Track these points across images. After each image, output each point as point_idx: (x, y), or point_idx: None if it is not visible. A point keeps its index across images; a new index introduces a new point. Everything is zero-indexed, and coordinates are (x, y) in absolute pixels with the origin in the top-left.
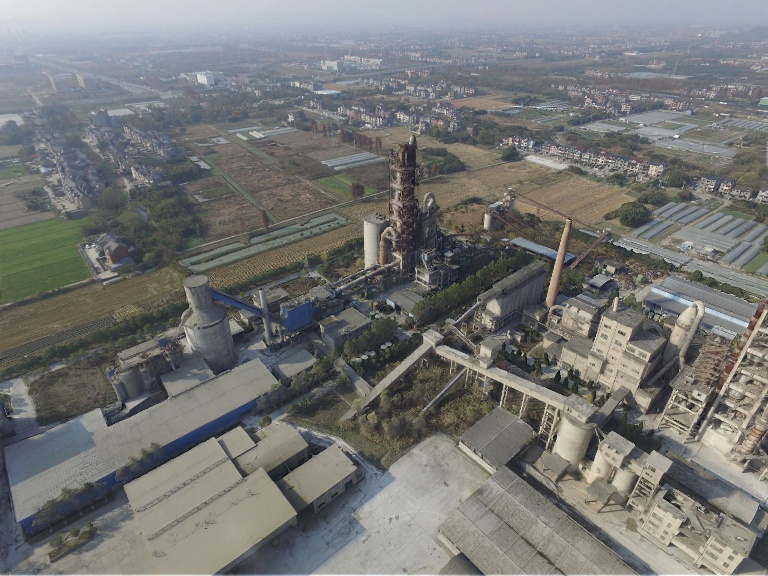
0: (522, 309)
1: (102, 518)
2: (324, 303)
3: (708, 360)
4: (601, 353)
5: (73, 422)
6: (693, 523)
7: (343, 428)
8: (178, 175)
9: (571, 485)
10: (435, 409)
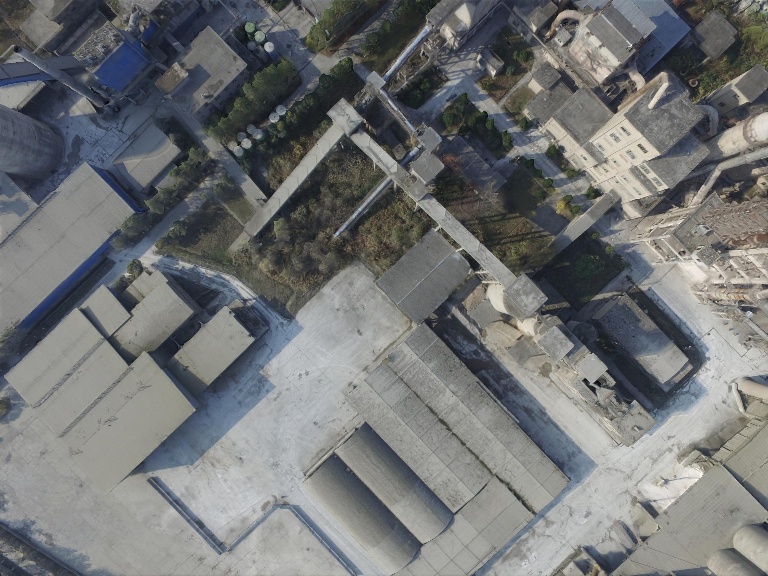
0: (512, 3)
1: (8, 388)
2: (160, 5)
3: (743, 226)
4: (602, 150)
5: None
6: None
7: (236, 263)
8: None
9: (497, 329)
10: (351, 232)
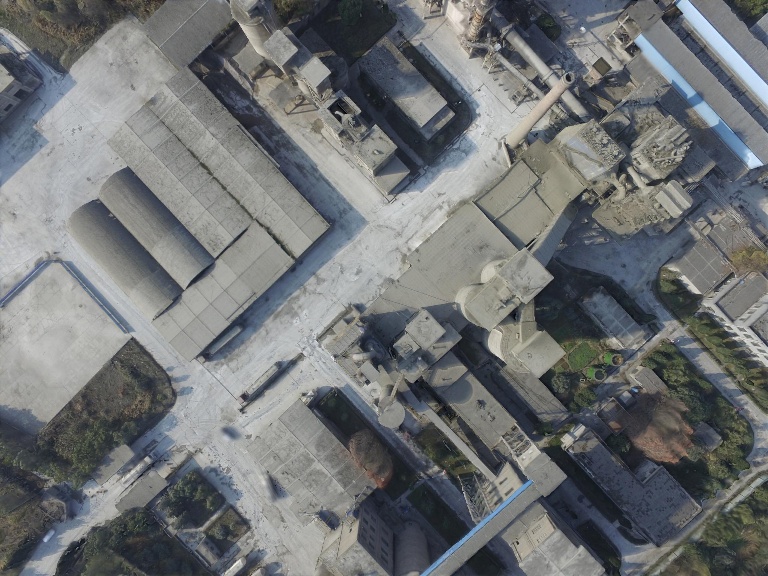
0: None
1: None
2: None
3: None
4: None
5: None
6: None
7: (8, 14)
8: None
9: (269, 83)
10: None
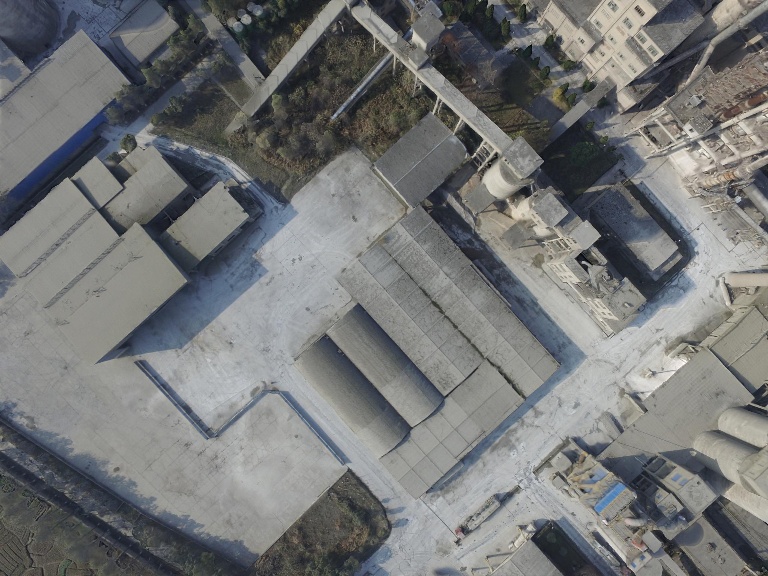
0: None
1: None
2: None
3: (736, 85)
4: (599, 27)
5: None
6: (592, 283)
7: (232, 144)
8: None
9: (492, 218)
10: (348, 115)
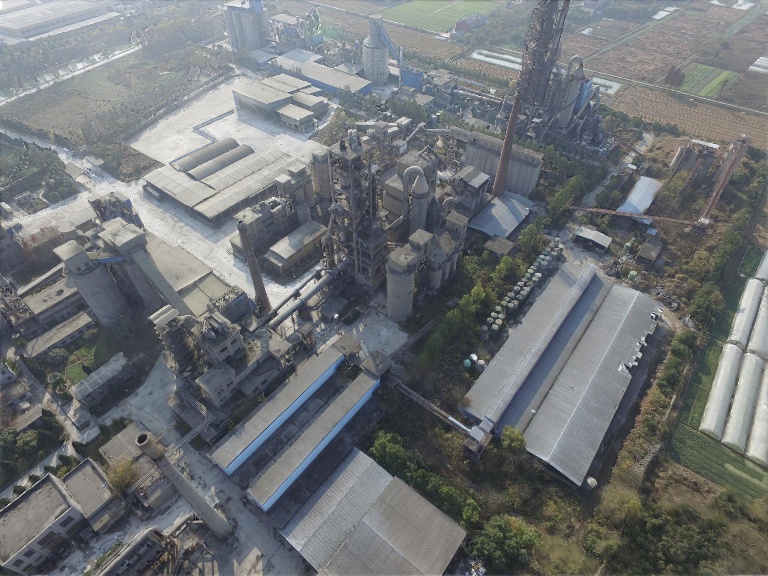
0: None
1: None
2: (442, 92)
3: None
4: None
5: (313, 54)
6: None
7: None
8: (613, 10)
9: None
10: None
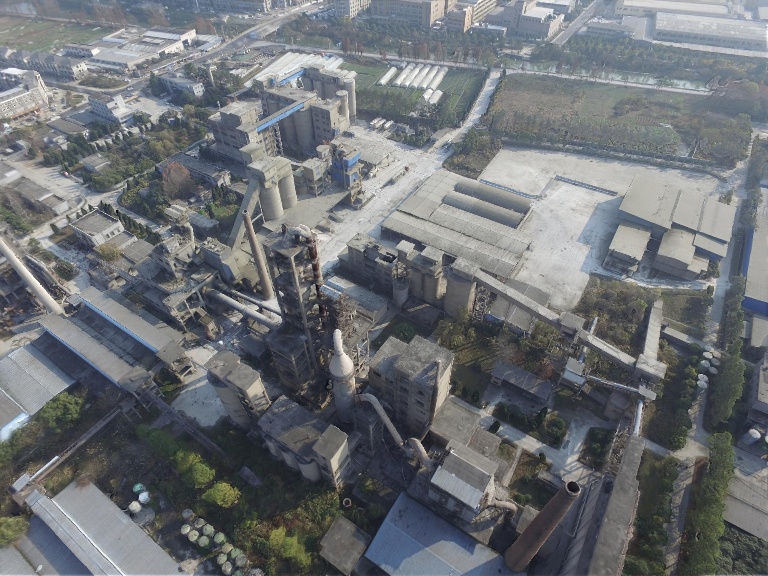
0: None
1: None
2: None
3: None
4: None
5: None
6: None
7: None
8: None
9: None
10: (587, 323)
